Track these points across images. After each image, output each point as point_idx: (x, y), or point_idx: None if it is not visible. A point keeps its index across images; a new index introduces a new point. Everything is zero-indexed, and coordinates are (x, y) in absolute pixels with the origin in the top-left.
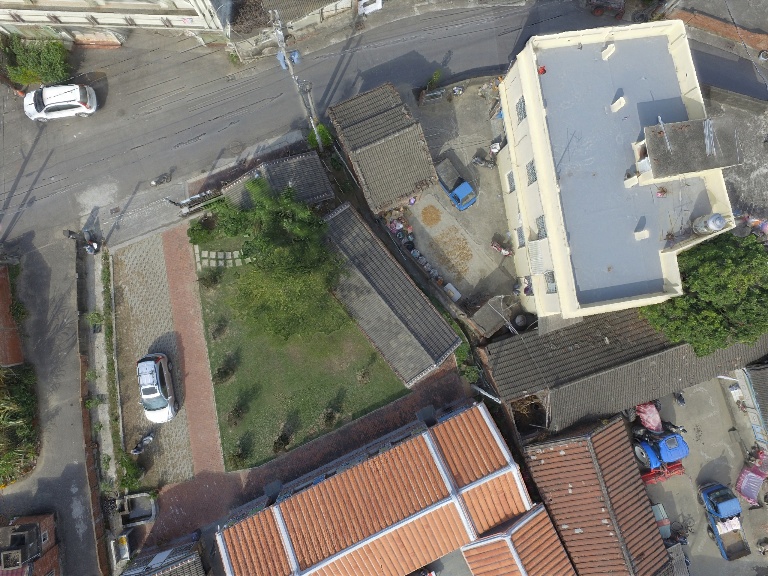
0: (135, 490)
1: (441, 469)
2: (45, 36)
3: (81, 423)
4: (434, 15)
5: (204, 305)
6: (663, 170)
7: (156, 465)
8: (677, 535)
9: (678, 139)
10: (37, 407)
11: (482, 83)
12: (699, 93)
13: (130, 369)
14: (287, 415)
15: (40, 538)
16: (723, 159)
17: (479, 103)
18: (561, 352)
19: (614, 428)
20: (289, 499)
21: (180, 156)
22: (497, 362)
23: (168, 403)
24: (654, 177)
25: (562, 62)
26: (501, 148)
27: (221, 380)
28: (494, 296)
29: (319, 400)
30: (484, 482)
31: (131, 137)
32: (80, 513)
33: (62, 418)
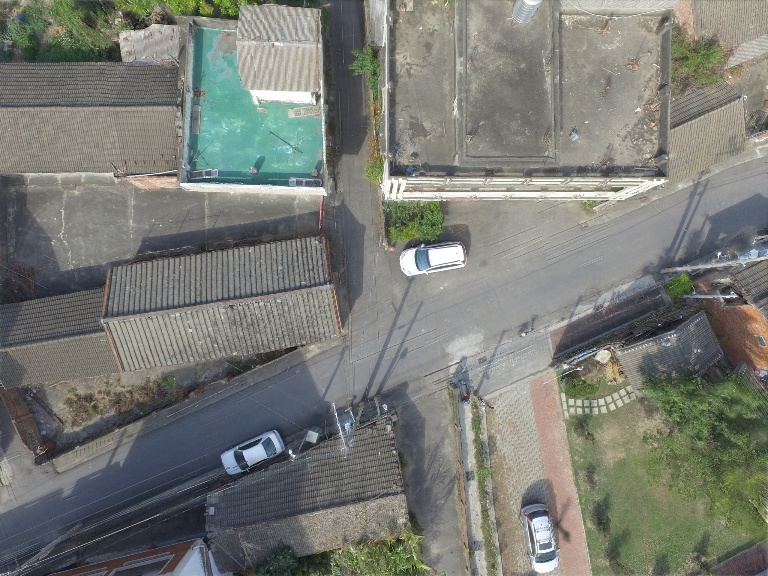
0: None
1: None
2: None
3: (461, 570)
4: None
5: (573, 452)
6: None
7: None
8: None
9: None
10: None
11: None
12: None
13: (506, 517)
14: (655, 560)
15: None
16: None
17: None
18: None
19: None
20: None
21: (541, 305)
22: None
23: (557, 555)
24: None
25: None
26: None
27: None
28: None
29: (685, 544)
30: None
31: (494, 287)
32: None
33: (444, 566)
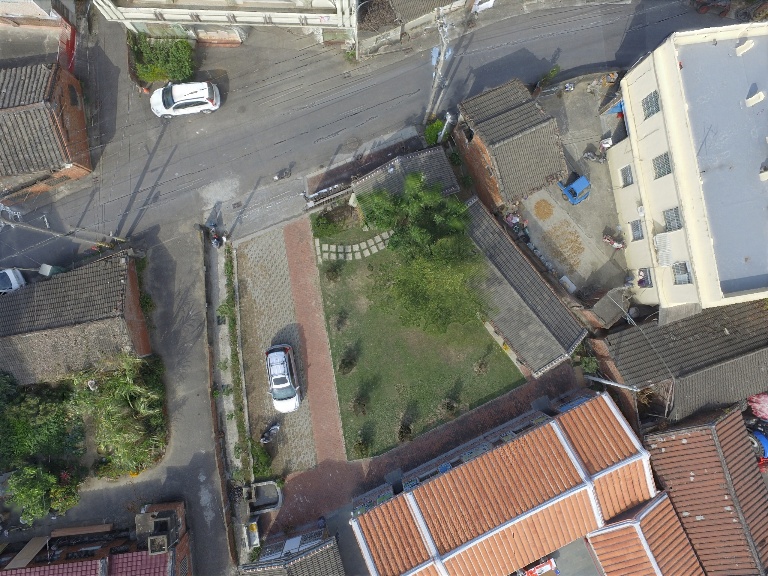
0: (261, 478)
1: (572, 456)
2: (170, 35)
3: (207, 413)
4: (543, 13)
5: (325, 297)
6: None
7: (280, 454)
8: None
9: None
10: (165, 397)
11: (592, 80)
12: None
13: (254, 360)
14: (406, 405)
15: (177, 524)
16: None
17: (588, 99)
18: (682, 342)
19: (733, 417)
20: (422, 486)
21: (299, 152)
22: (618, 352)
23: (296, 393)
24: None
25: (698, 58)
26: (613, 143)
27: (348, 370)
28: (613, 288)
29: (437, 390)
30: (615, 469)
31: (252, 133)
32: (208, 501)
33: (189, 408)
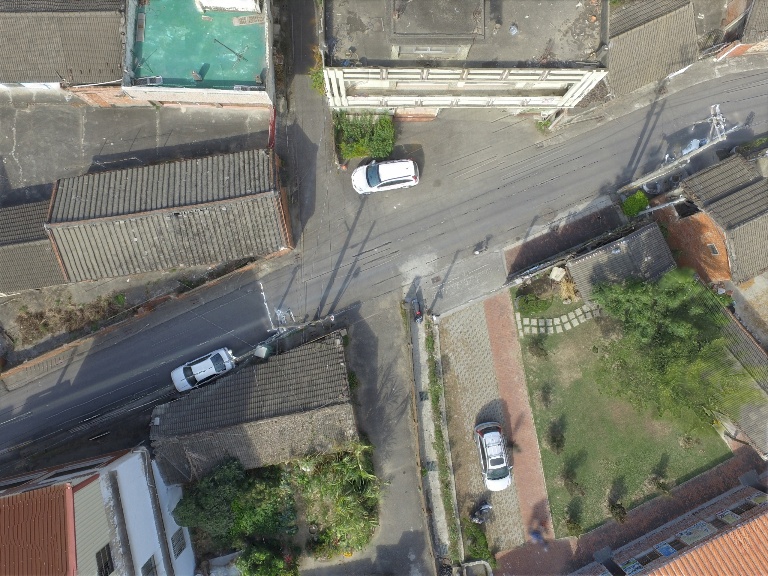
0: (469, 557)
1: None
2: (368, 111)
3: (414, 491)
4: (735, 77)
5: (527, 372)
6: None
7: (488, 532)
8: None
9: None
10: None
11: None
12: None
13: (459, 437)
14: (612, 481)
15: None
16: None
17: None
18: None
19: None
20: (652, 572)
21: (495, 224)
22: None
23: (509, 472)
24: None
25: None
26: None
27: None
28: None
29: (643, 466)
30: None
31: (448, 207)
32: None
33: (396, 486)
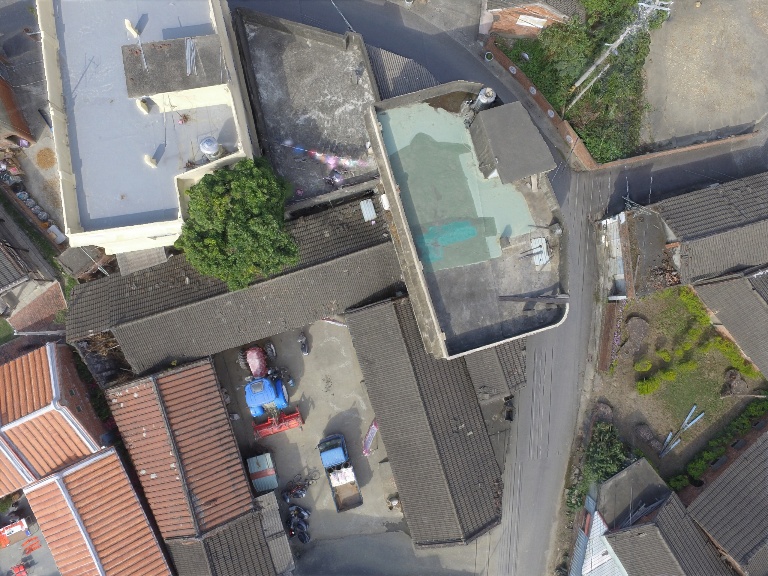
0: None
1: None
2: None
3: None
4: None
5: None
6: (139, 89)
7: None
8: (295, 487)
9: (157, 58)
10: None
11: None
12: (212, 16)
13: None
14: None
15: None
16: (206, 79)
17: None
18: (139, 292)
19: (197, 371)
20: None
21: None
22: (76, 302)
23: None
24: (129, 96)
25: None
26: None
27: None
28: None
29: None
30: (27, 420)
31: None
32: None
33: None
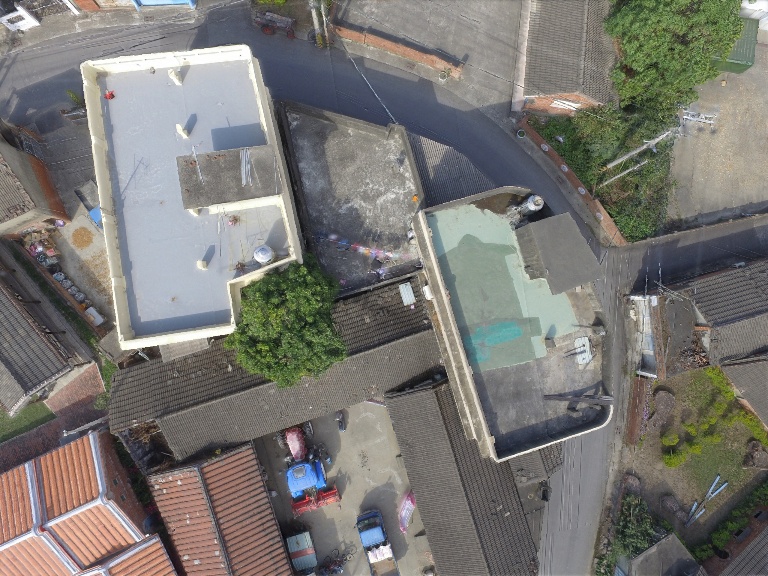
0: None
1: (32, 501)
2: None
3: None
4: (96, 32)
5: None
6: (194, 201)
7: None
8: (333, 563)
9: (212, 169)
10: None
11: None
12: (262, 120)
13: None
14: None
15: None
16: (260, 189)
17: None
18: (182, 380)
19: (239, 457)
20: None
21: None
22: (118, 389)
23: None
24: (184, 208)
25: (132, 87)
26: None
27: None
28: None
29: None
30: (73, 514)
31: None
32: None
33: None
